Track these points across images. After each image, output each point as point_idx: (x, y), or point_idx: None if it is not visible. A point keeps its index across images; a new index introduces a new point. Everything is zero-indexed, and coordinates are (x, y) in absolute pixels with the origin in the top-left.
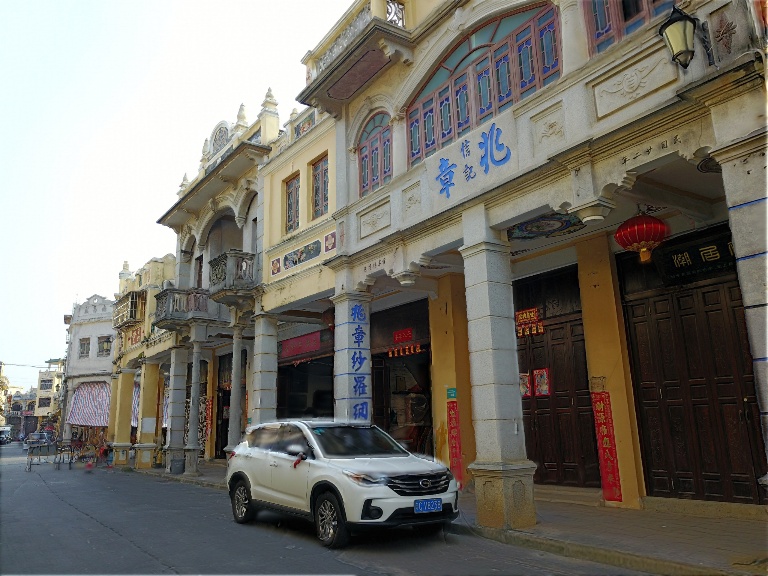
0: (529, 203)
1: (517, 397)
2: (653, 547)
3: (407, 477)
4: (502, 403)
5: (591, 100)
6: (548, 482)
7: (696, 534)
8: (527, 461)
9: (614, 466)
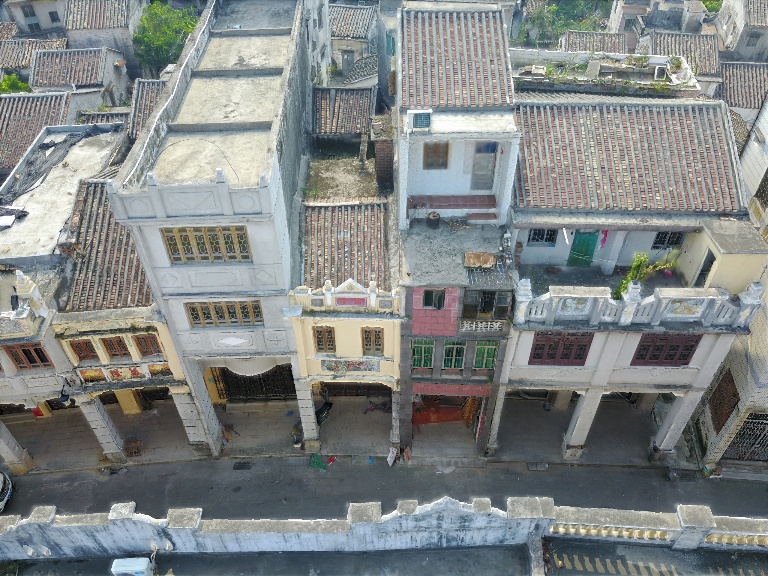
0: (2, 402)
1: (13, 439)
2: (77, 459)
3: (1, 494)
4: (11, 447)
5: (23, 382)
6: (5, 413)
7: (80, 436)
8: (24, 450)
9: (37, 408)
